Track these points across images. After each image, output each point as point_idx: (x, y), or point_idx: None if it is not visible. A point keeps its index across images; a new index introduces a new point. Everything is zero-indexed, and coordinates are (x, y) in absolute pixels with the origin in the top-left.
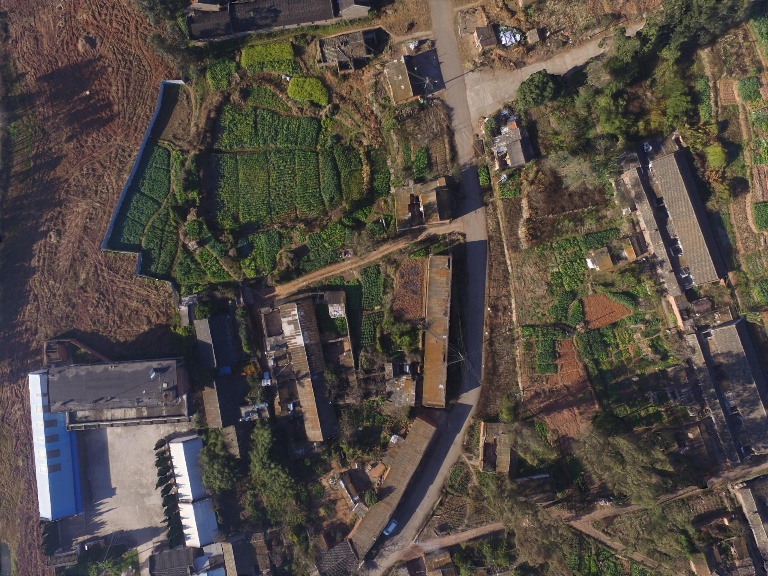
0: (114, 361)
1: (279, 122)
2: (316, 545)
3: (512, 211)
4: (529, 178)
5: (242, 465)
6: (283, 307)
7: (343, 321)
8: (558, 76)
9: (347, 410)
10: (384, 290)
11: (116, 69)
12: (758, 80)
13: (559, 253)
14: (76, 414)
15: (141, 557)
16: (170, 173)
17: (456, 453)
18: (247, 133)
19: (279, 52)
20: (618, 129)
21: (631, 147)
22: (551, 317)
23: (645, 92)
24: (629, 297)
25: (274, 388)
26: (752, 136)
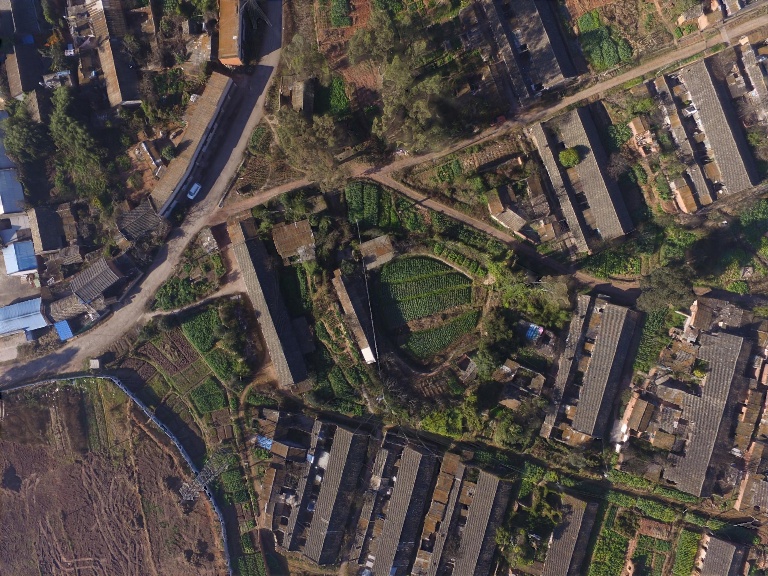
0: None
1: None
2: (119, 209)
3: None
4: None
5: (43, 129)
6: None
7: None
8: None
9: (148, 73)
10: None
11: None
12: None
13: None
14: None
15: None
16: None
17: (258, 115)
18: None
19: None
20: None
21: None
22: None
23: None
24: None
25: (77, 57)
26: None
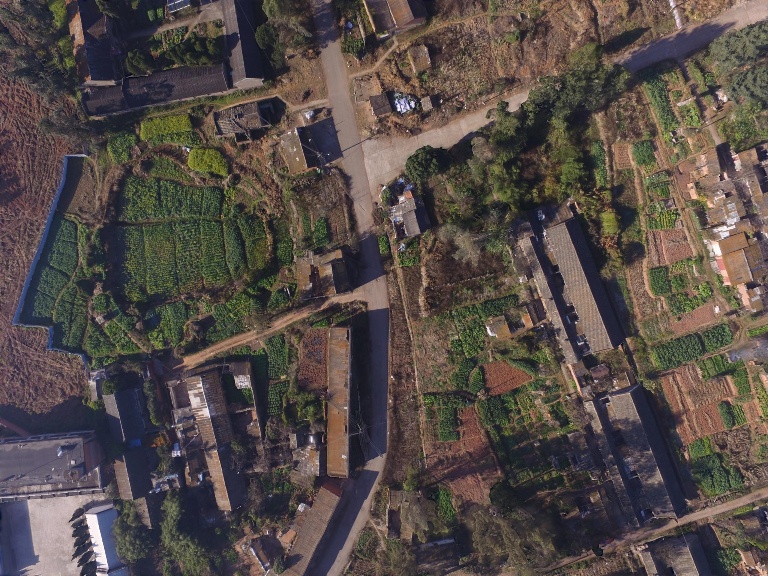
0: (31, 433)
1: (182, 193)
2: None
3: (412, 279)
4: (428, 246)
5: (154, 535)
6: (189, 380)
7: (250, 391)
8: (444, 151)
9: (255, 480)
10: (289, 359)
11: (20, 143)
12: (652, 143)
13: (459, 321)
14: None
15: None
16: (78, 246)
17: (364, 518)
18: (151, 205)
19: (177, 125)
20: (511, 198)
21: (524, 216)
22: (452, 385)
23: (540, 157)
24: (528, 364)
25: (184, 459)
26: (647, 201)
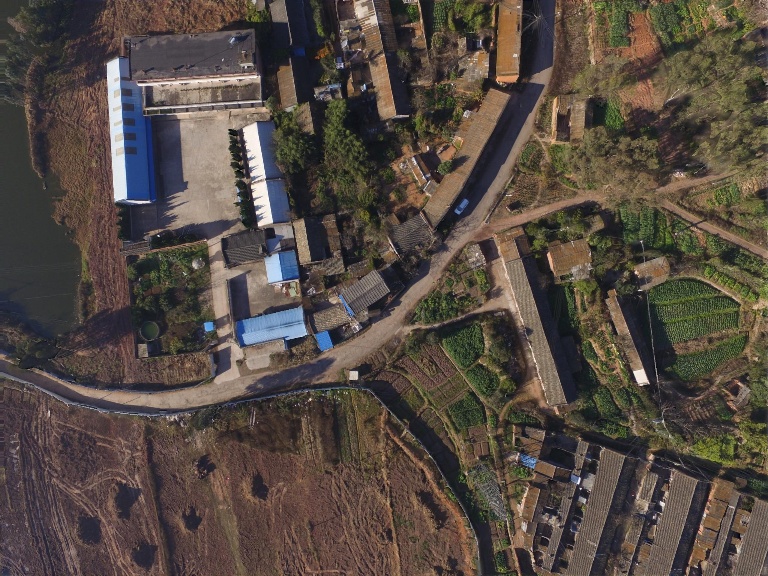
0: None
1: None
2: (388, 222)
3: None
4: None
5: (316, 141)
6: None
7: (415, 9)
8: None
9: (420, 88)
10: None
11: None
12: None
13: None
14: (153, 99)
15: (211, 251)
16: None
17: (528, 133)
18: None
19: None
20: None
21: None
22: None
23: None
24: None
25: (347, 70)
26: None
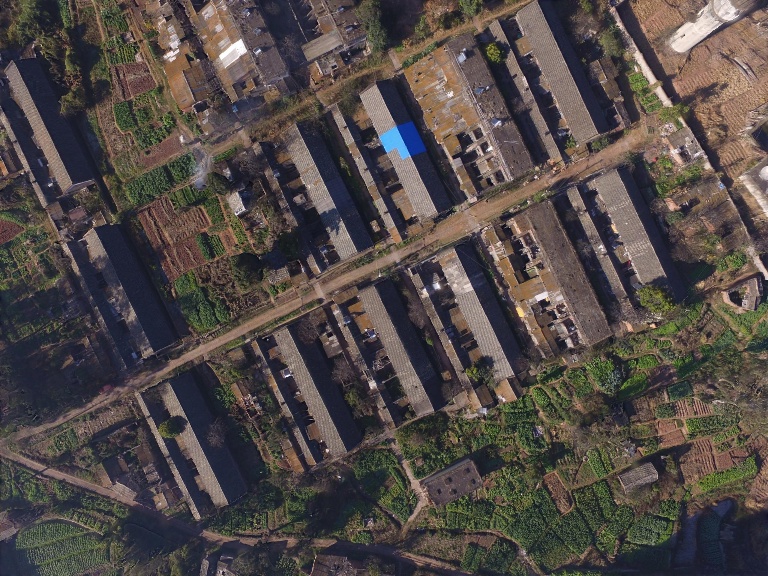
0: None
1: None
2: None
3: None
4: None
5: None
6: None
7: None
8: None
9: None
10: None
11: None
12: None
13: None
14: None
15: None
16: None
17: None
18: None
19: None
20: None
21: None
22: None
23: (9, 4)
24: (15, 214)
25: None
26: (107, 36)
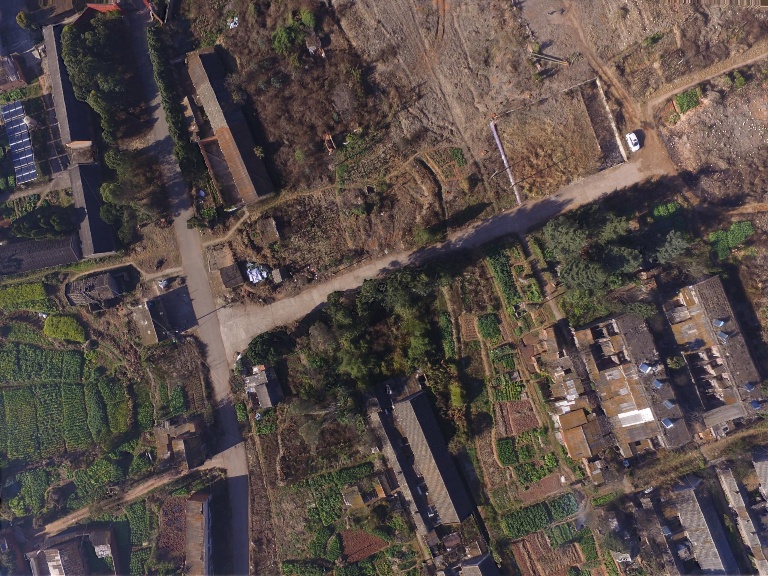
0: None
1: (42, 357)
2: None
3: (269, 447)
4: (284, 414)
5: None
6: (47, 552)
7: None
8: (283, 337)
9: None
10: (151, 526)
11: None
12: (497, 317)
13: (315, 489)
14: None
15: None
16: None
17: None
18: (10, 370)
19: (31, 294)
20: (359, 372)
21: (371, 392)
22: (310, 552)
23: (390, 328)
24: (384, 531)
25: None
26: (493, 373)
